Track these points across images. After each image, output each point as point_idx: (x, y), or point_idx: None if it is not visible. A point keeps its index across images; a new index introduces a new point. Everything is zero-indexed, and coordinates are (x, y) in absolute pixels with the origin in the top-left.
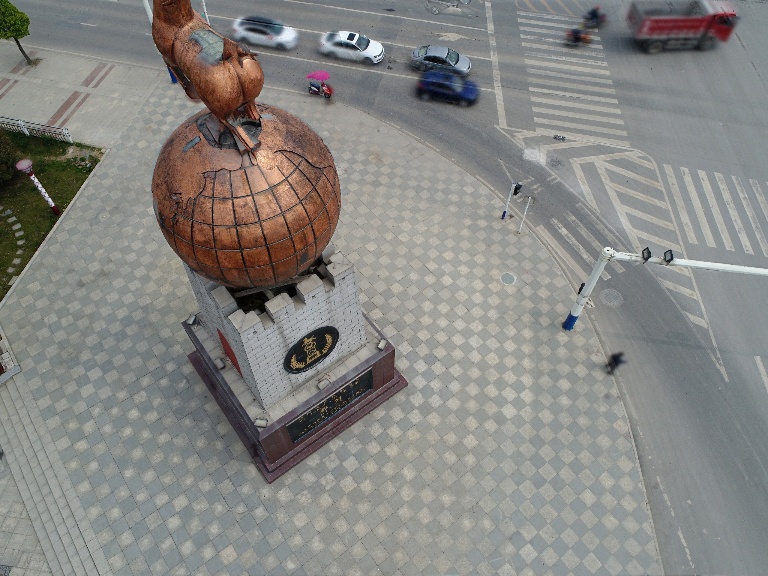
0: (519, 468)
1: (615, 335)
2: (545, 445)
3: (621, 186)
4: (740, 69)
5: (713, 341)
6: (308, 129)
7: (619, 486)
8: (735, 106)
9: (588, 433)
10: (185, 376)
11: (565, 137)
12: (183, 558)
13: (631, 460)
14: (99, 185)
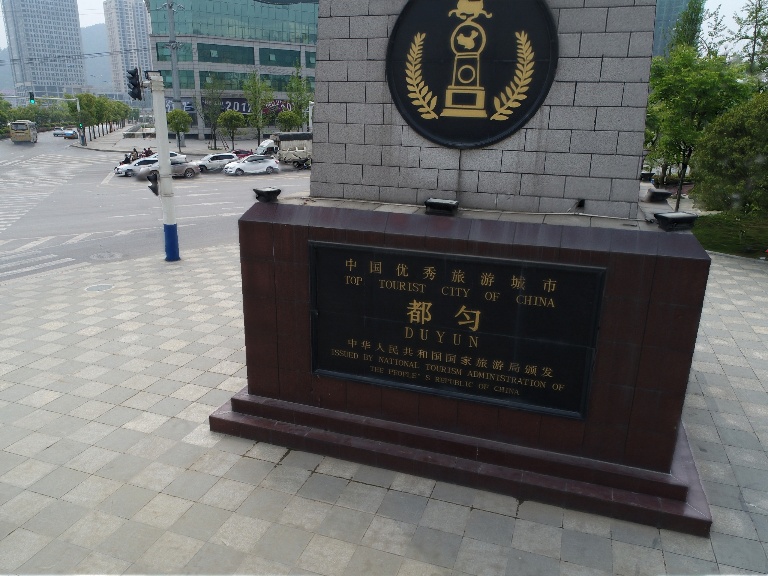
0: None
1: None
2: None
3: None
4: None
5: (150, 228)
6: None
7: None
8: None
9: None
10: (746, 512)
11: None
12: None
13: None
14: None
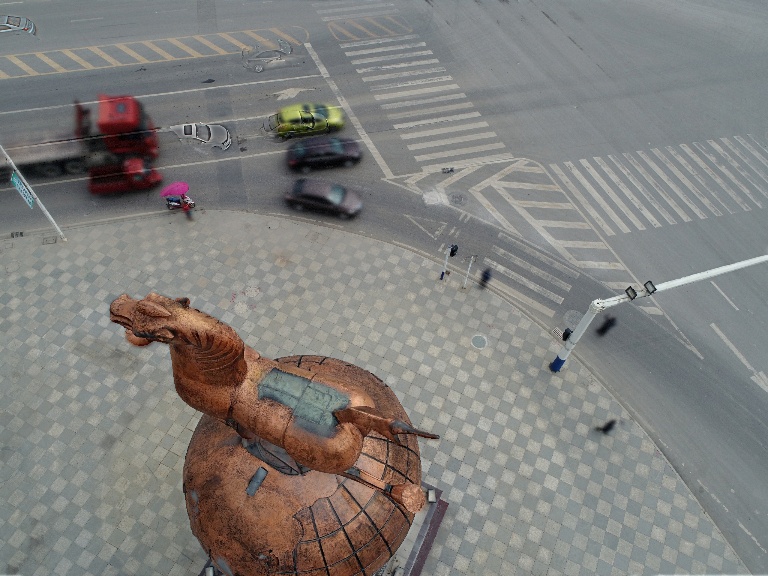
0: (590, 538)
1: (596, 356)
2: (598, 501)
3: (526, 201)
4: (563, 47)
5: (673, 325)
6: (360, 375)
7: (676, 508)
8: (577, 85)
9: (626, 469)
10: None
11: (453, 168)
12: None
13: (672, 476)
14: None
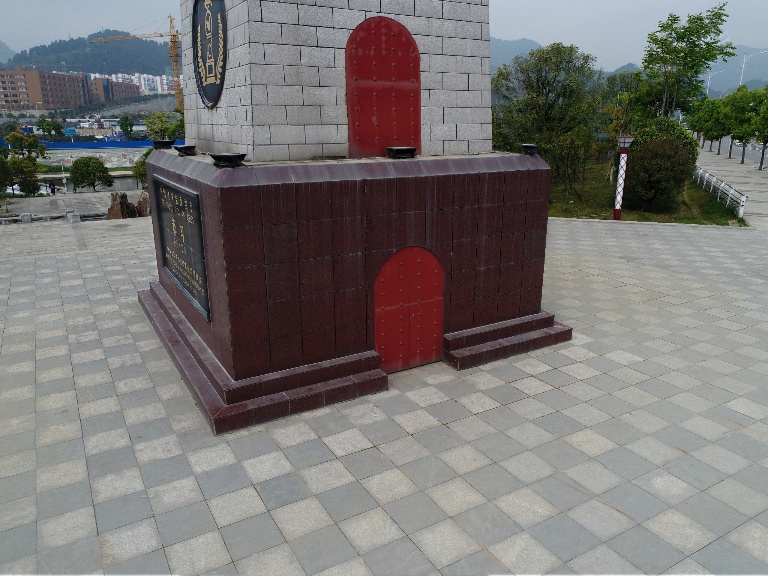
0: None
1: None
2: None
3: None
4: None
5: None
6: None
7: None
8: None
9: None
10: None
11: None
12: (105, 266)
13: None
14: (679, 229)
